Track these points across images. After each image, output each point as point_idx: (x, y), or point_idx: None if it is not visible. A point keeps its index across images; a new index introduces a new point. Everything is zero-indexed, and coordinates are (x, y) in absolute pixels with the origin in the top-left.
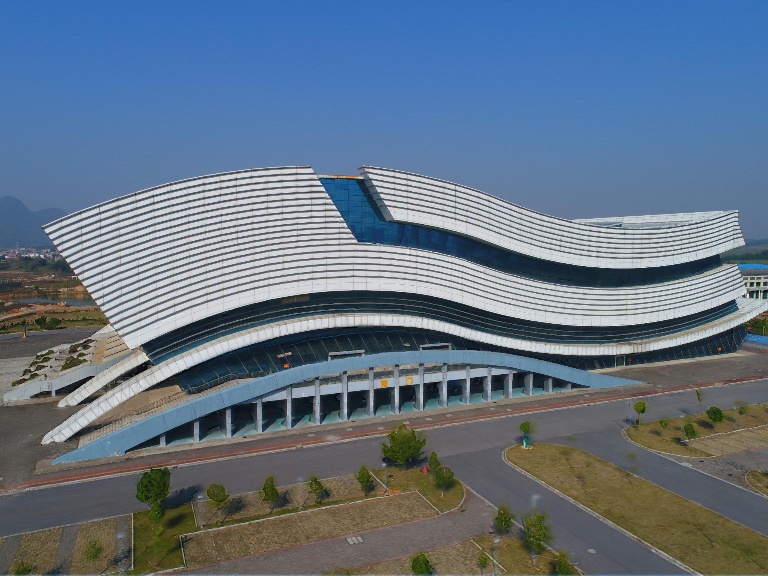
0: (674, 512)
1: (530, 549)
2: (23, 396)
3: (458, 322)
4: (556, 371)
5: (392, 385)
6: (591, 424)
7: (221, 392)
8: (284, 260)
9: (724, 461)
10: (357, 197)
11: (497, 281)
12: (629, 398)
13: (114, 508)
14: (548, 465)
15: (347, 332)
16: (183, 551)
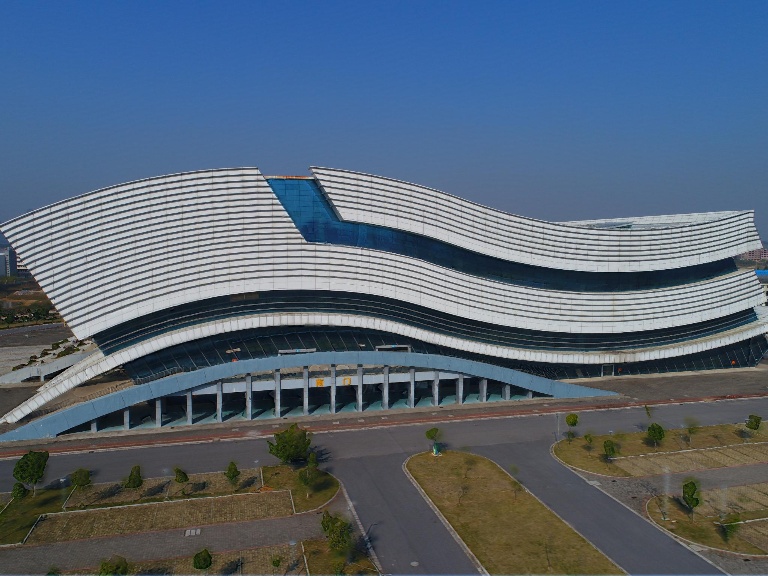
0: (535, 532)
1: (351, 556)
2: (15, 380)
3: (418, 324)
4: (513, 378)
5: (328, 385)
6: (525, 435)
7: (149, 384)
8: (230, 259)
9: (639, 482)
10: (309, 197)
11: (460, 283)
12: (591, 410)
13: (8, 485)
14: (443, 474)
15: (297, 330)
16: (32, 529)
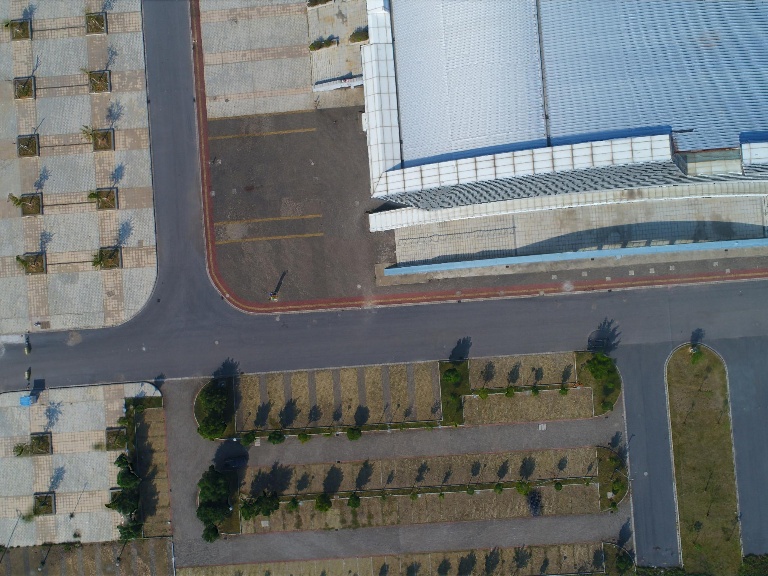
0: (713, 459)
1: (618, 465)
2: (328, 89)
3: None
4: None
5: None
6: None
7: (498, 264)
8: None
9: None
10: None
11: None
12: None
13: (428, 351)
14: (688, 382)
15: None
16: (463, 411)
